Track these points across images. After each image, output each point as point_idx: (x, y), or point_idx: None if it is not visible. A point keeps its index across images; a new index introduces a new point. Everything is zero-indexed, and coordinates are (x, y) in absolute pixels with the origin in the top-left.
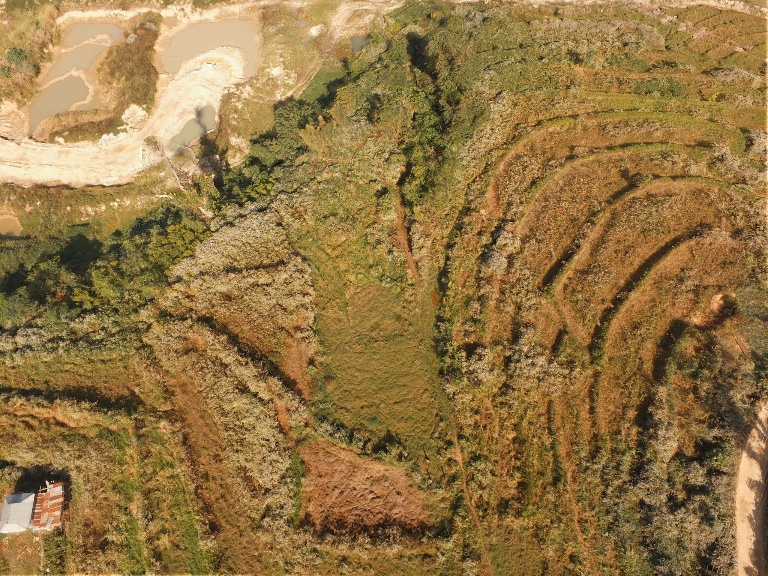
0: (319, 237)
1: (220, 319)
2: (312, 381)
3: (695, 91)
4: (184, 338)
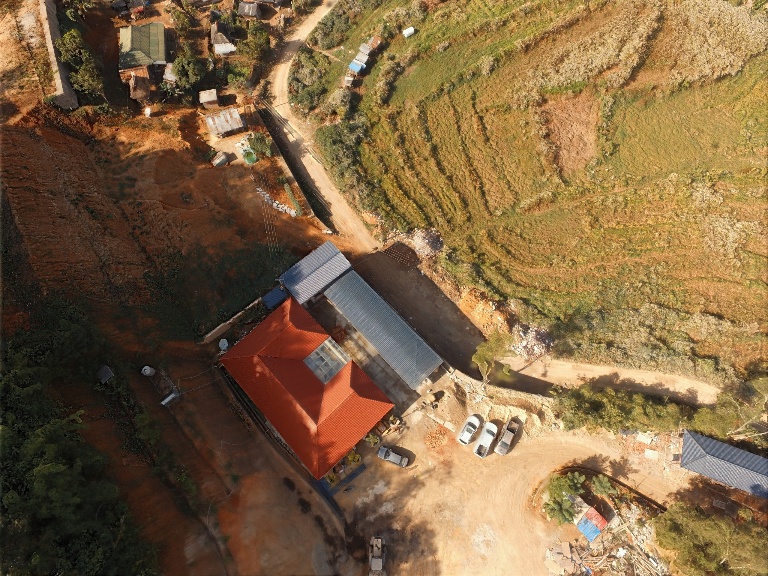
0: (766, 80)
1: (666, 25)
2: (640, 89)
3: None
4: (645, 3)
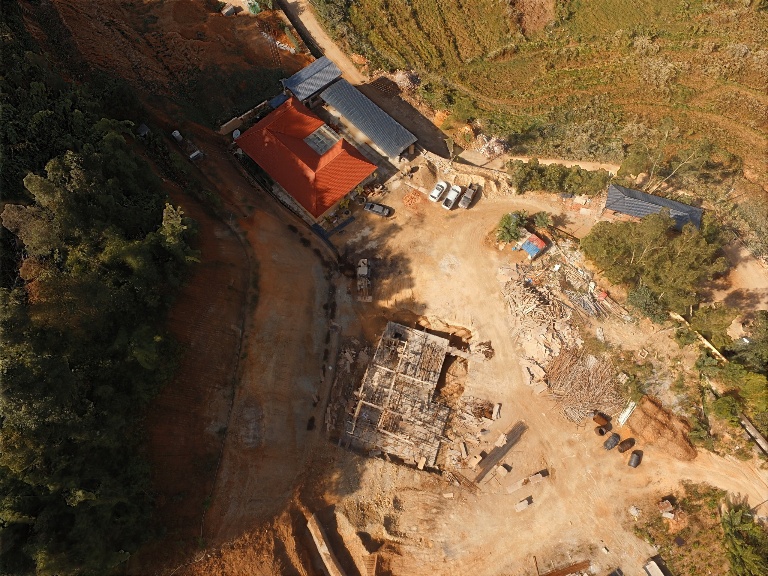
0: None
1: None
2: None
3: None
4: None
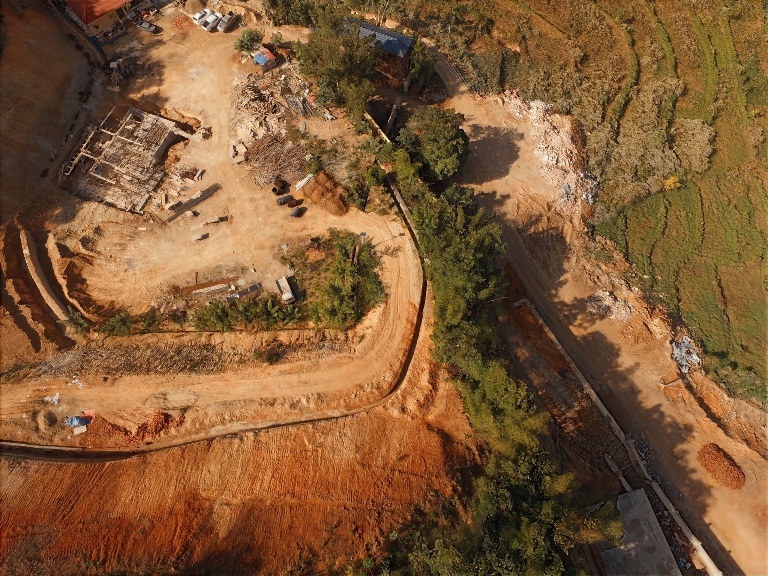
0: None
1: None
2: None
3: (760, 112)
4: None
